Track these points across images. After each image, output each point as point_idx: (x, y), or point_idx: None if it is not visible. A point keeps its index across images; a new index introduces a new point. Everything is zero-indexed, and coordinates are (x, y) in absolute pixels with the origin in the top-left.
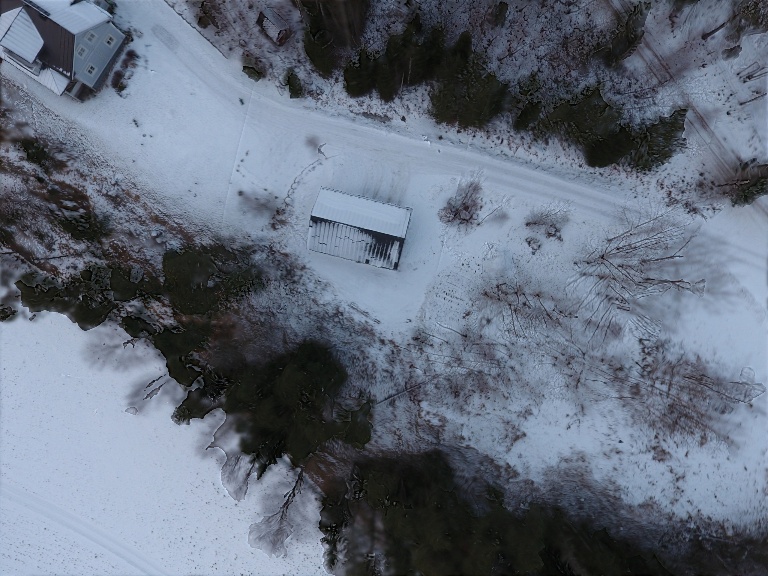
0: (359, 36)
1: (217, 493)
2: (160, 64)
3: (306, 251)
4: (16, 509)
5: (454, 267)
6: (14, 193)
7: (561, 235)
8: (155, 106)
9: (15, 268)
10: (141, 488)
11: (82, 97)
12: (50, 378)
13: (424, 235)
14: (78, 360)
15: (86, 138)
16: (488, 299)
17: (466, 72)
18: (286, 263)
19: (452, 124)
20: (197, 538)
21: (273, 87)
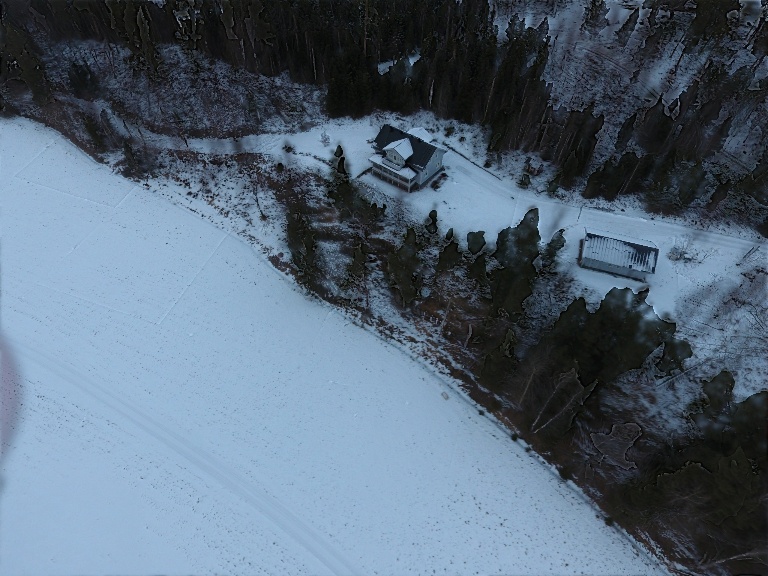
0: (585, 173)
1: (479, 509)
2: (460, 180)
3: (573, 269)
4: (249, 514)
5: (691, 286)
6: (328, 252)
7: (767, 272)
8: (457, 196)
9: (310, 301)
10: (391, 501)
11: (411, 190)
12: (318, 383)
13: (660, 266)
14: (347, 370)
15: (408, 210)
16: (730, 306)
17: (674, 170)
18: (554, 281)
19: (658, 213)
20: (453, 571)
21: (532, 193)
